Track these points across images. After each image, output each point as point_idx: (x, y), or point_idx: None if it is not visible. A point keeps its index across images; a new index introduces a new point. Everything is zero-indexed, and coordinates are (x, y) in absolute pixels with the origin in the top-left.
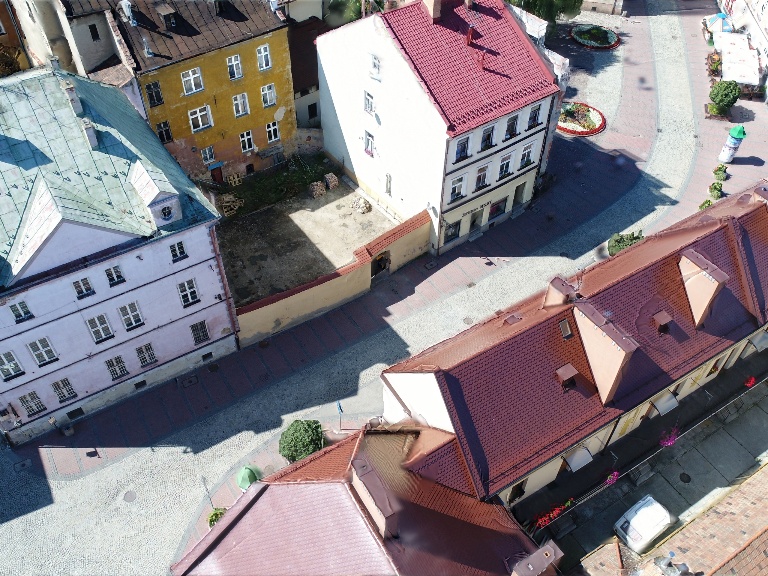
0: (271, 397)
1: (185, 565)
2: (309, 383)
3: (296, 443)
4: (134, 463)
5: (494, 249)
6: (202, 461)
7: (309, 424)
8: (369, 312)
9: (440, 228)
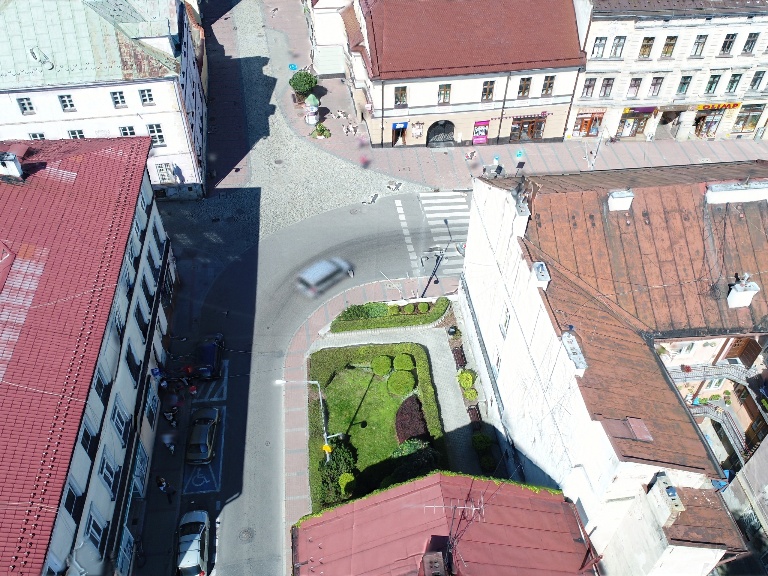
0: (253, 104)
1: (376, 68)
2: (255, 91)
3: (307, 77)
4: (257, 157)
5: (217, 14)
6: (276, 135)
7: (300, 71)
8: (223, 62)
9: (198, 6)
